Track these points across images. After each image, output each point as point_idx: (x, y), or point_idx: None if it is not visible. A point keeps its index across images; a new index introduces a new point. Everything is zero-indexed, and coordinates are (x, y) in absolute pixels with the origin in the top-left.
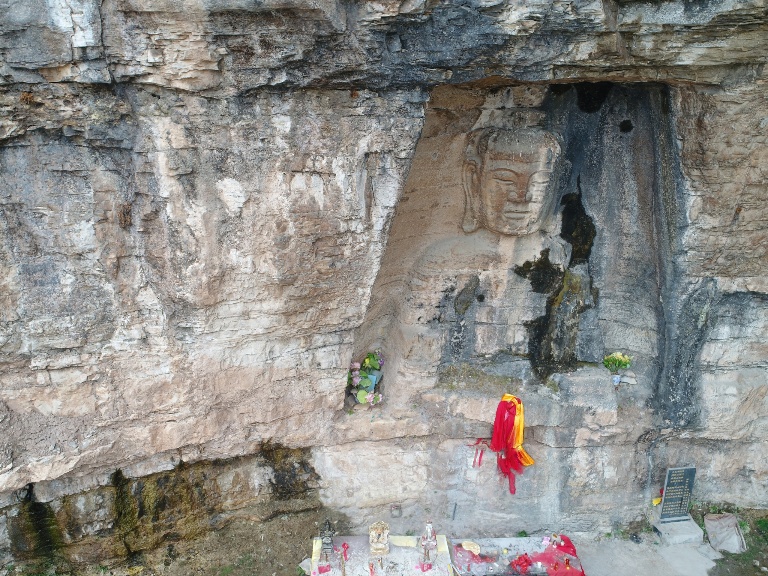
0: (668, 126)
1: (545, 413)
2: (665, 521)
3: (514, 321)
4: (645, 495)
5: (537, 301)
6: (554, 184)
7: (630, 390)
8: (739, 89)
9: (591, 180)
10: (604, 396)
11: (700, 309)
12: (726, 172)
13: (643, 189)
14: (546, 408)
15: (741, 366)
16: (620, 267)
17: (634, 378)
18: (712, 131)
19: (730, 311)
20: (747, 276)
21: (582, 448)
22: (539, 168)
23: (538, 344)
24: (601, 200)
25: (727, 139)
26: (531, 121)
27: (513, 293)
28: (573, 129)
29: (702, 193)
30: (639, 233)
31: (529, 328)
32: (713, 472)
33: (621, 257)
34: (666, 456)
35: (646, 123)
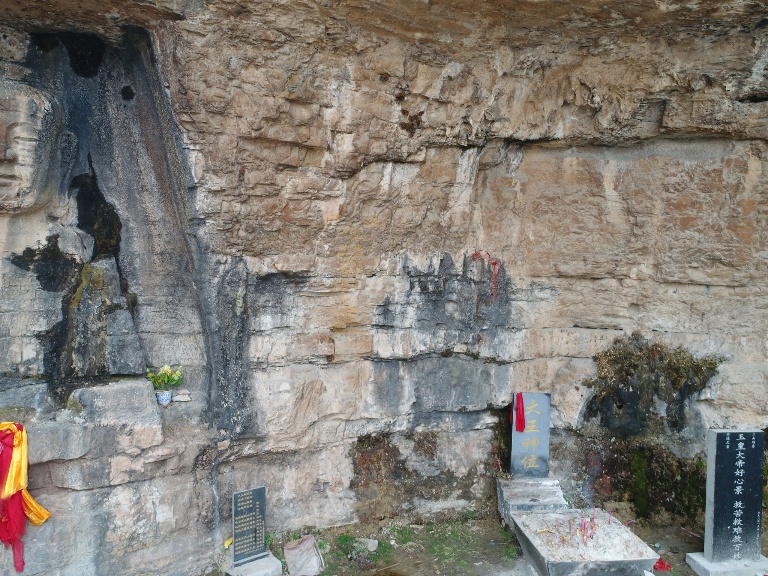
0: (157, 78)
1: (61, 440)
2: (239, 563)
3: (20, 331)
4: (214, 537)
5: (50, 302)
6: (48, 148)
7: (182, 407)
8: (198, 17)
9: (104, 159)
10: (142, 408)
11: (235, 292)
12: (215, 120)
13: (158, 164)
14: (62, 433)
15: (292, 361)
16: (155, 265)
17: (188, 395)
18: (187, 66)
19: (270, 300)
20: (273, 254)
21: (123, 486)
22: (20, 119)
23: (57, 360)
24: (119, 182)
25: (204, 77)
26: (12, 74)
27: (14, 293)
28: (72, 96)
29: (201, 147)
30: (165, 218)
31: (43, 340)
32: (288, 493)
33: (154, 252)
34: (233, 482)
35: (145, 87)
